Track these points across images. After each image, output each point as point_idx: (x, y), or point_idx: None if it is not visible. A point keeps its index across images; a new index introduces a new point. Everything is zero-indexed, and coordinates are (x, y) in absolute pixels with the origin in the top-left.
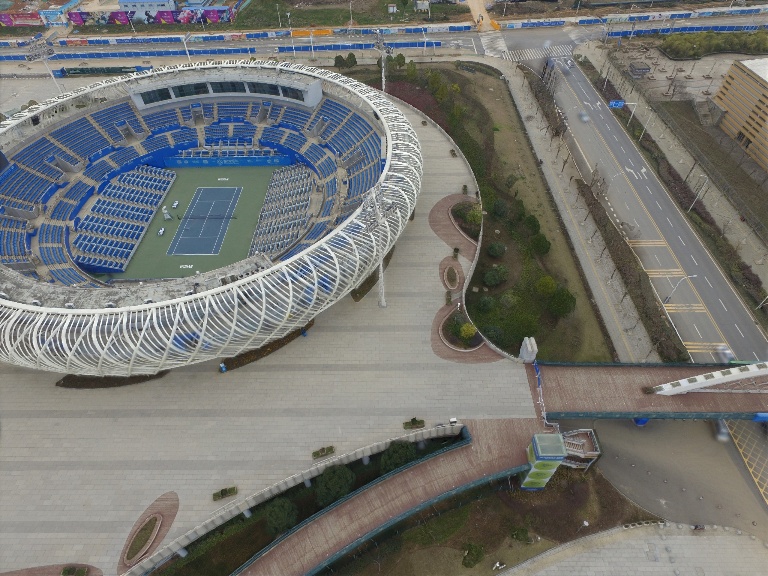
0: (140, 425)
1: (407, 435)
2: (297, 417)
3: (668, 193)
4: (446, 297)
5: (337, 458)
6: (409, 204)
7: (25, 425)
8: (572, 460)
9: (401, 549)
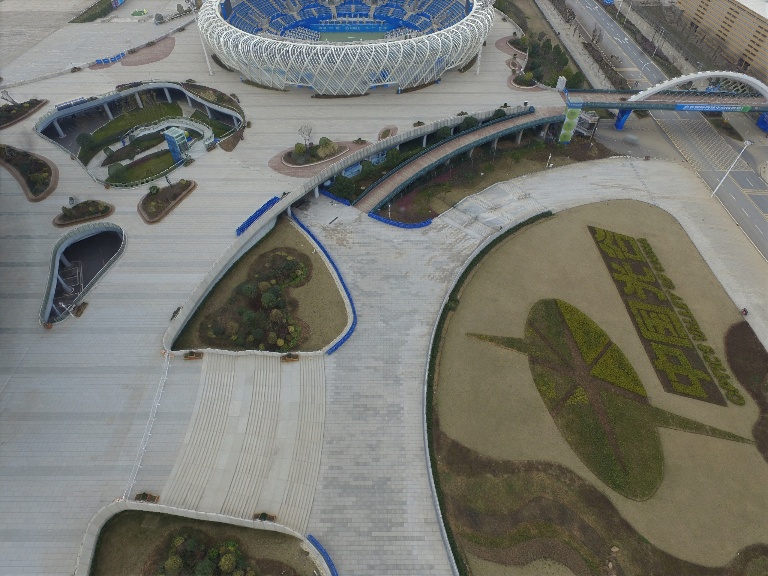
0: (364, 108)
1: (503, 108)
2: (444, 106)
3: (641, 49)
4: (513, 71)
5: (470, 114)
6: (491, 21)
7: (304, 108)
8: (584, 128)
9: (502, 158)
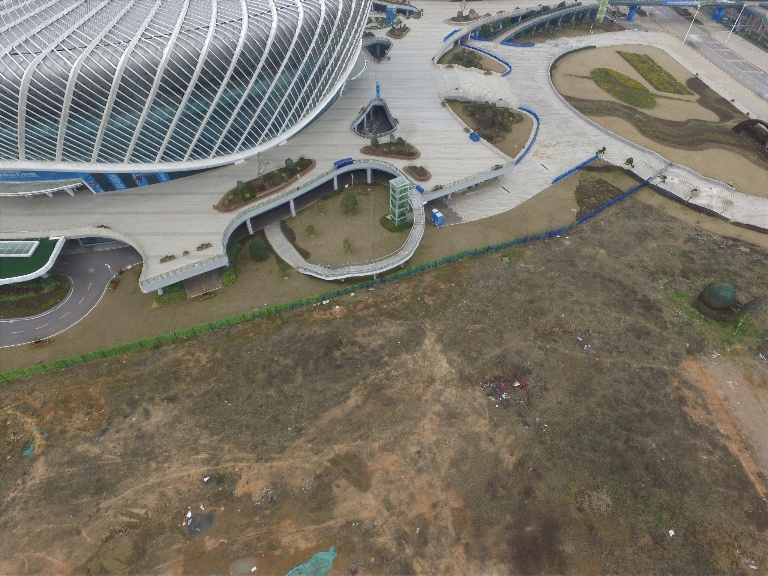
0: None
1: None
2: None
3: None
4: None
5: (545, 5)
6: None
7: (449, 5)
8: (610, 15)
9: (564, 29)
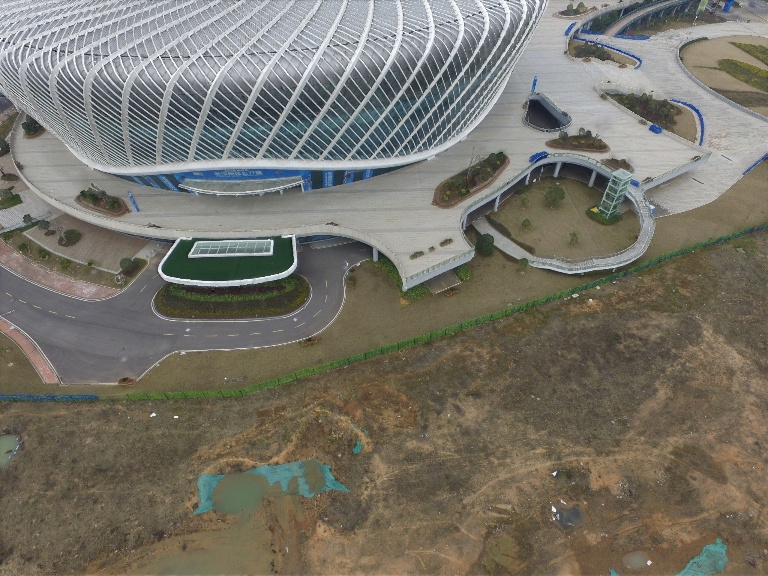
0: None
1: None
2: None
3: None
4: None
5: None
6: None
7: None
8: None
9: None
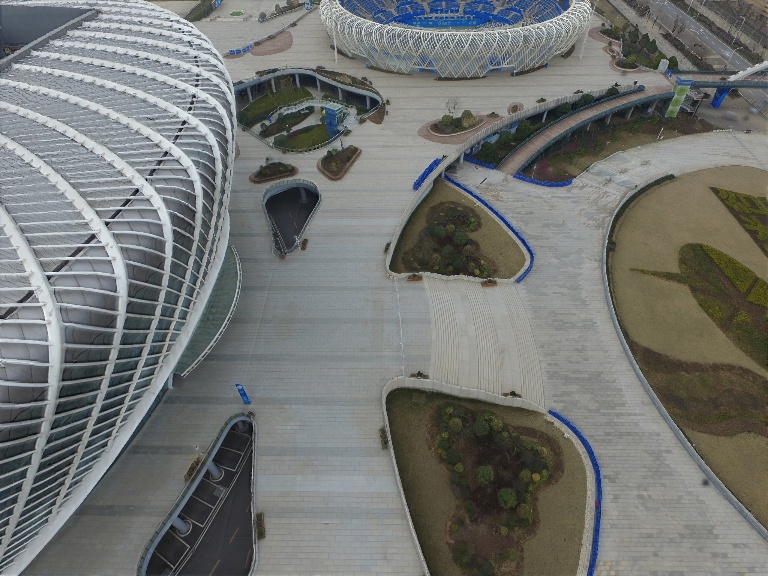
0: (487, 88)
1: (615, 87)
2: (559, 86)
3: (718, 39)
4: (612, 56)
5: (587, 92)
6: None
7: (432, 89)
8: (689, 105)
9: (616, 131)
